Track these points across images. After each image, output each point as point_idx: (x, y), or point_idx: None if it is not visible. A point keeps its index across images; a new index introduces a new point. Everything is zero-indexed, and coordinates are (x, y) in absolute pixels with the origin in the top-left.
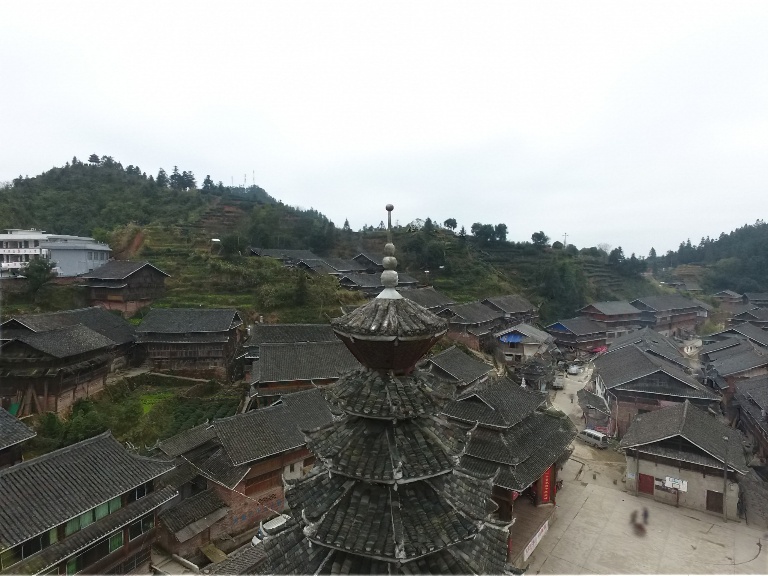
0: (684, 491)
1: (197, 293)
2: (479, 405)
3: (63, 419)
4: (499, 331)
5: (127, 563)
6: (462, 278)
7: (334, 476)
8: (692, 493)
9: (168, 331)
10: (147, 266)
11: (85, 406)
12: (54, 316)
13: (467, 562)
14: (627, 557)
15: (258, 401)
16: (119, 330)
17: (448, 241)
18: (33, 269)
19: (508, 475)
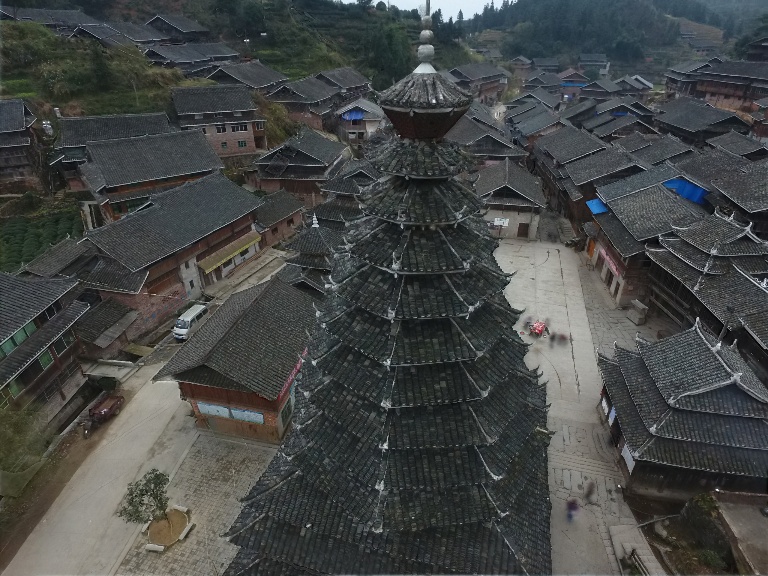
0: (506, 226)
1: None
2: (365, 180)
3: None
4: (338, 108)
5: (61, 375)
6: (288, 48)
7: (387, 231)
8: (509, 227)
9: None
10: None
11: None
12: None
13: (487, 267)
14: None
15: (110, 208)
16: None
17: None
18: None
19: None
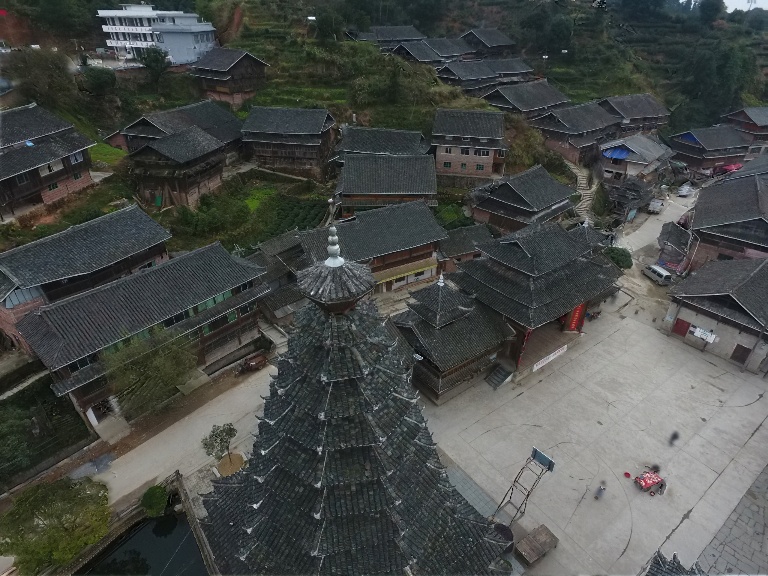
0: (710, 342)
1: (294, 86)
2: (519, 250)
3: (194, 210)
4: (608, 141)
5: (242, 328)
6: (586, 67)
7: None
8: (722, 343)
9: (268, 131)
10: (246, 55)
11: (208, 200)
12: (174, 113)
13: (369, 421)
14: (624, 384)
15: (342, 208)
16: (229, 126)
17: (582, 13)
18: (150, 59)
19: (526, 314)
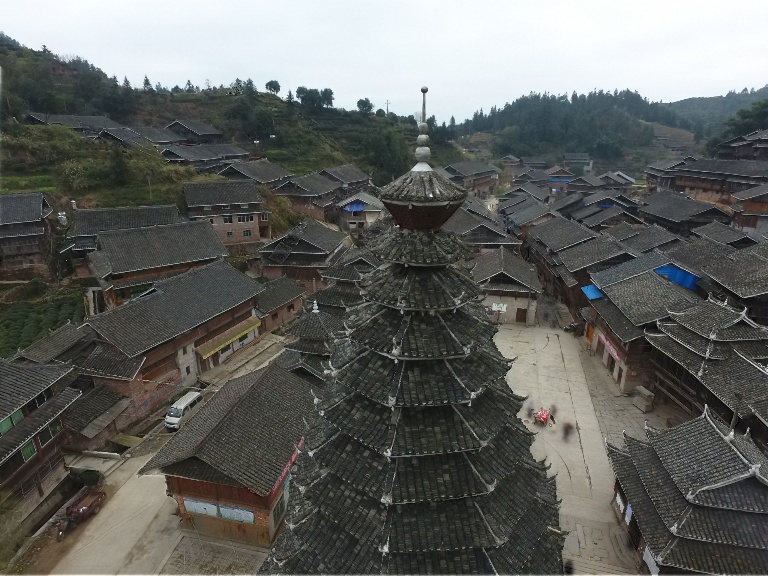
0: (504, 311)
1: None
2: (365, 267)
3: None
4: (340, 201)
5: (42, 468)
6: (295, 148)
7: (387, 316)
8: (507, 312)
9: None
10: None
11: None
12: None
13: (488, 353)
14: None
15: (113, 294)
16: None
17: (274, 107)
18: None
19: None
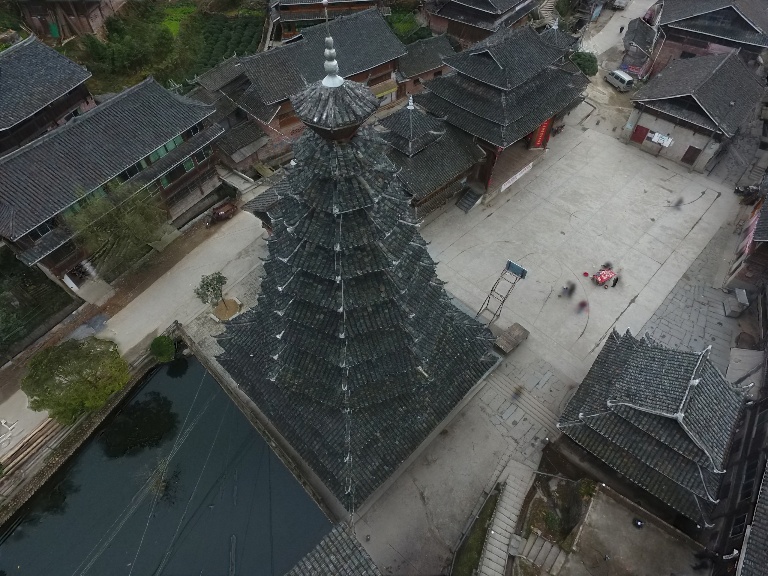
0: (666, 146)
1: None
2: (489, 62)
3: (103, 40)
4: None
5: (201, 177)
6: None
7: None
8: (675, 147)
9: None
10: None
11: (117, 26)
12: None
13: (381, 248)
14: (585, 195)
15: (282, 25)
16: None
17: None
18: None
19: (497, 133)
